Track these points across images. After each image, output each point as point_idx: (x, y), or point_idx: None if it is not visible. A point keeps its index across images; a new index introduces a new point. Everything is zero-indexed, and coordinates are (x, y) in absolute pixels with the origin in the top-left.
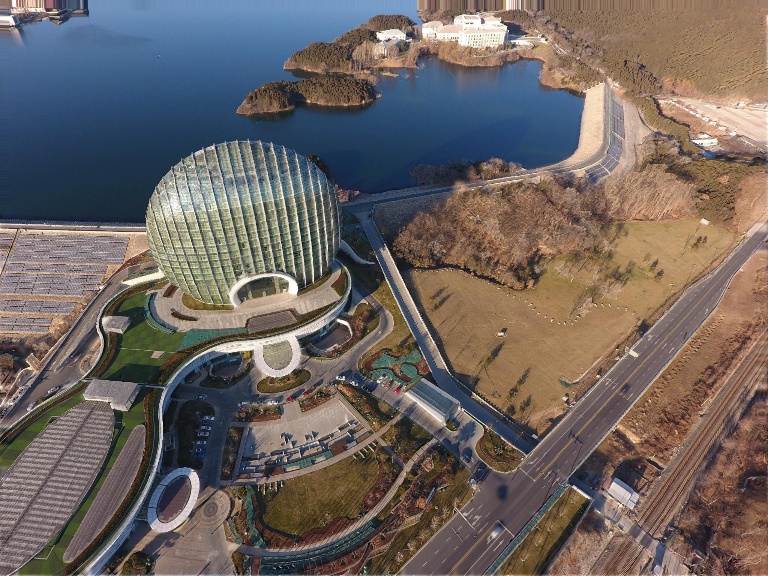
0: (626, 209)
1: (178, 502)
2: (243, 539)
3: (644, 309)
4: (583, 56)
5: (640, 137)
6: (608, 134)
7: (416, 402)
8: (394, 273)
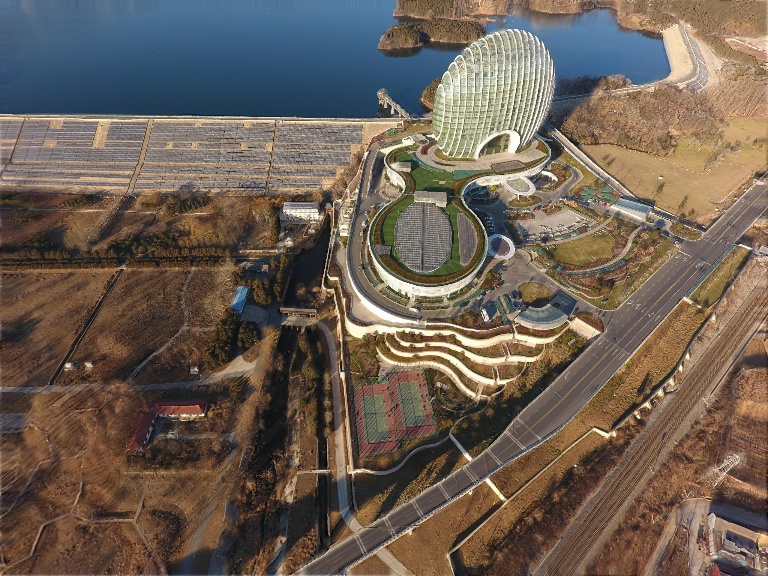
0: (724, 109)
1: (504, 248)
2: (548, 267)
3: (755, 165)
4: (654, 3)
5: (716, 65)
6: (695, 60)
7: (620, 211)
8: (570, 146)
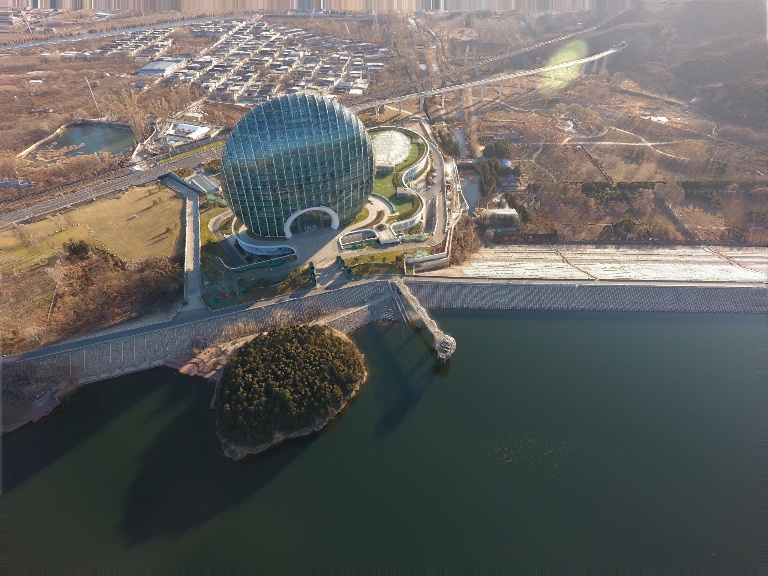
0: None
1: None
2: None
3: (2, 234)
4: None
5: None
6: None
7: None
8: (190, 250)
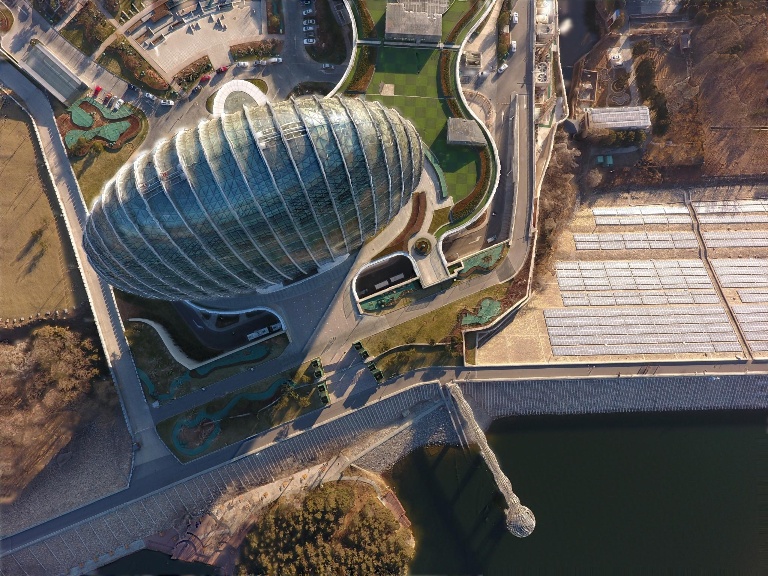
0: None
1: None
2: None
3: None
4: None
5: None
6: None
7: (76, 75)
8: (98, 298)
